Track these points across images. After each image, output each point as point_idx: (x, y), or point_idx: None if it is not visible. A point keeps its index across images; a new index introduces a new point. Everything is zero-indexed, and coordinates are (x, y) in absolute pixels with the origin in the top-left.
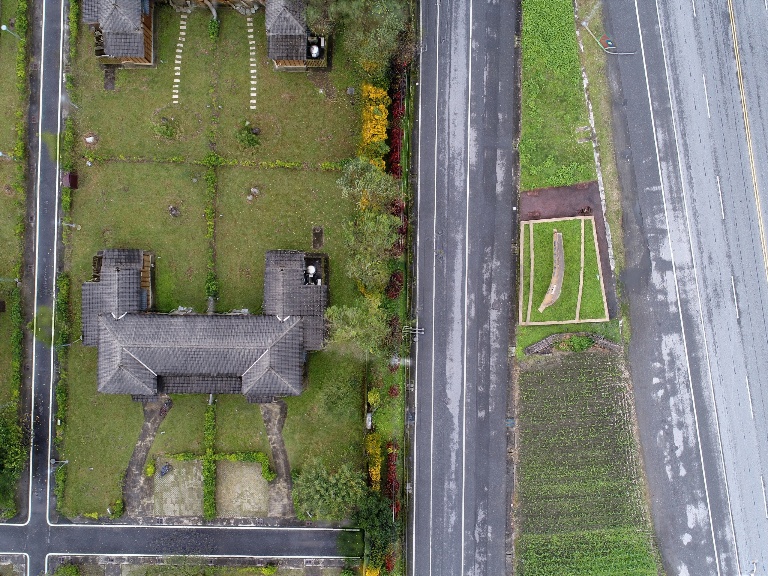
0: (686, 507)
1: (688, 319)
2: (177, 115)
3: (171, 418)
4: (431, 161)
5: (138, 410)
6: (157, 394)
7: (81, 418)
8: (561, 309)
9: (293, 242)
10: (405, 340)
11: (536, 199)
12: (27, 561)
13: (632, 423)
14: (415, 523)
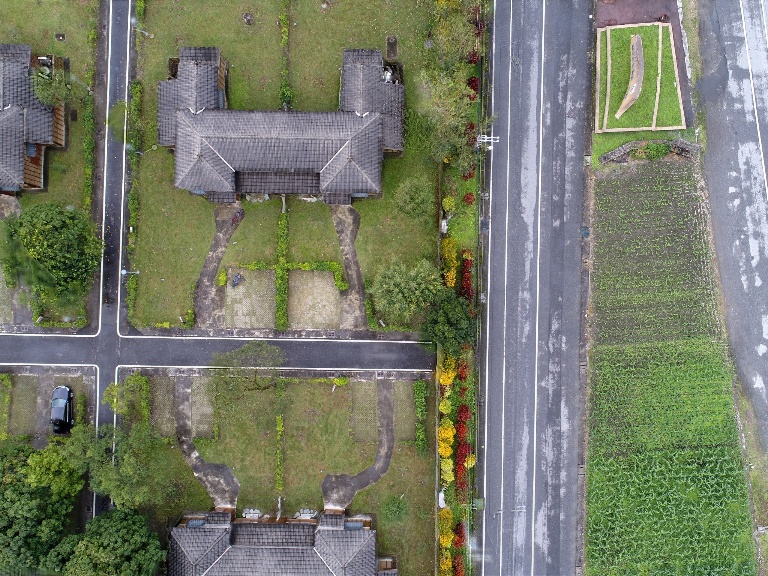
0: (761, 318)
1: (765, 128)
2: None
3: (243, 229)
4: None
5: (210, 220)
6: (233, 193)
7: (152, 228)
8: (638, 115)
9: None
10: (480, 148)
11: (613, 7)
12: (97, 373)
13: (708, 232)
14: (489, 333)
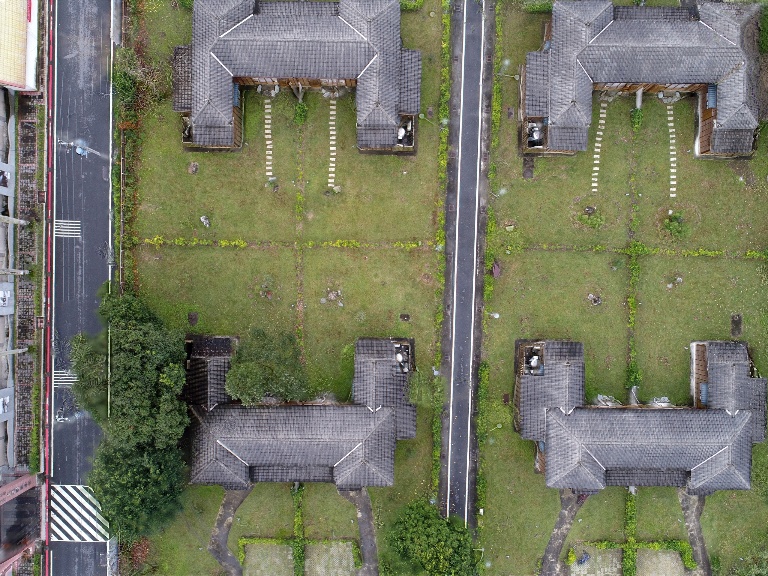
0: None
1: None
2: (599, 204)
3: (588, 506)
4: None
5: (555, 498)
6: None
7: (497, 506)
8: None
9: (713, 330)
10: None
11: None
12: None
13: None
14: None
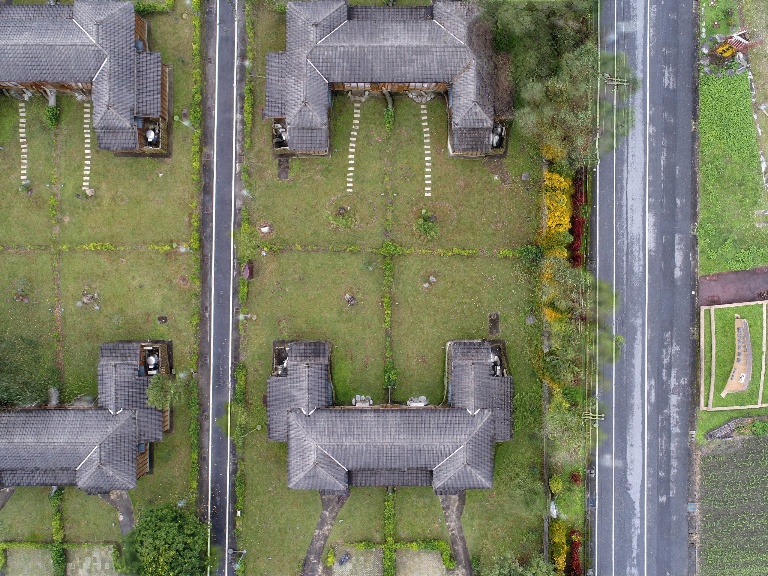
0: None
1: None
2: (353, 204)
3: (349, 506)
4: (609, 247)
5: (316, 499)
6: None
7: (258, 508)
8: (743, 394)
9: (470, 329)
10: (585, 426)
11: (715, 283)
12: None
13: None
14: None
